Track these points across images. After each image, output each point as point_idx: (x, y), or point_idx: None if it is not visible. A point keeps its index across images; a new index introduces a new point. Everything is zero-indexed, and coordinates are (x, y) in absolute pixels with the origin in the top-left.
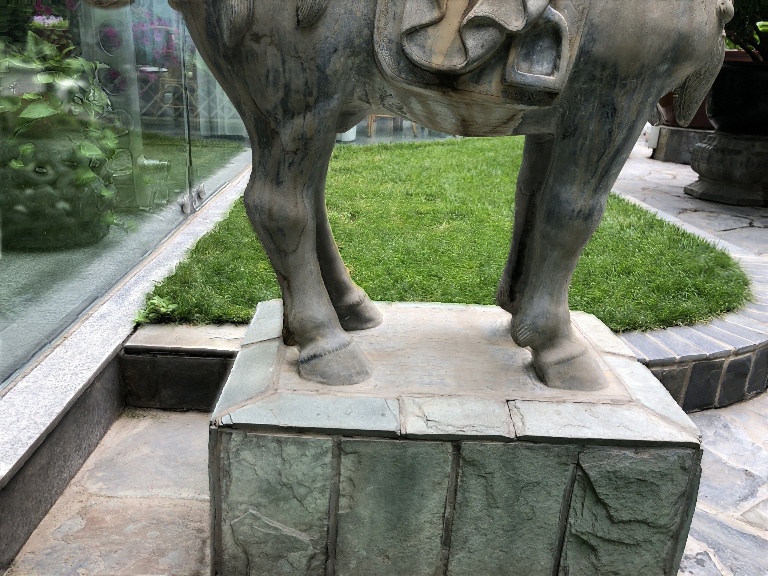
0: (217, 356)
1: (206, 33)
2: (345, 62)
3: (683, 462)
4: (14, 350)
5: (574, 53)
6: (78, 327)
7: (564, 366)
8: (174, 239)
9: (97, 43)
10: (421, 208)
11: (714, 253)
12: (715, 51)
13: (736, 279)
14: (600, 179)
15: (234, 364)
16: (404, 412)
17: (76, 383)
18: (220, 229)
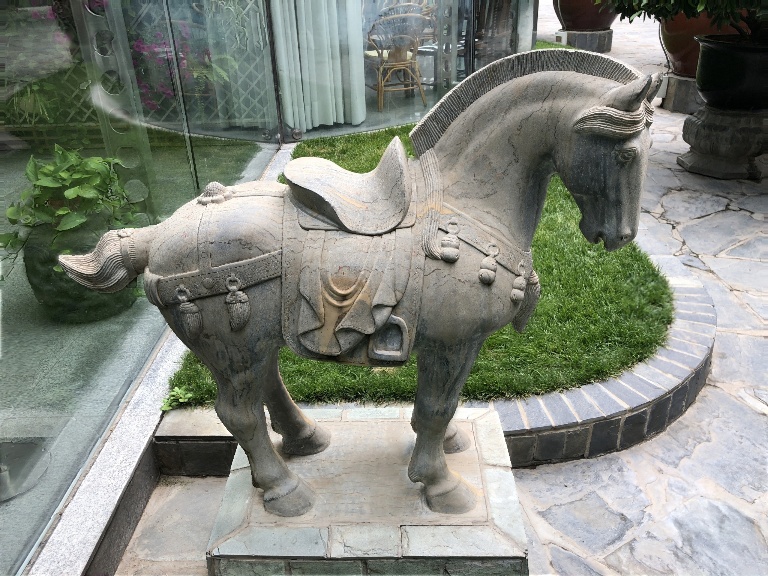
0: (223, 440)
1: (175, 328)
2: (266, 343)
3: (514, 567)
4: (76, 447)
5: (413, 337)
6: (120, 418)
7: (441, 498)
8: None
9: (109, 128)
10: None
11: (654, 282)
12: (531, 294)
13: (662, 317)
14: (449, 393)
15: None
16: (331, 539)
17: (122, 481)
18: None
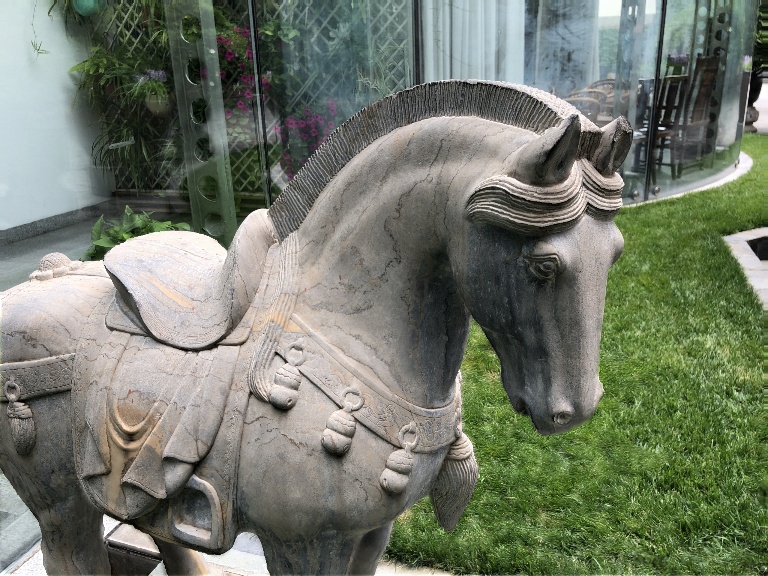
0: None
1: None
2: (66, 478)
3: None
4: (27, 533)
5: (230, 515)
6: None
7: None
8: None
9: (199, 194)
10: None
11: None
12: (453, 476)
13: None
14: None
15: None
16: None
17: None
18: None
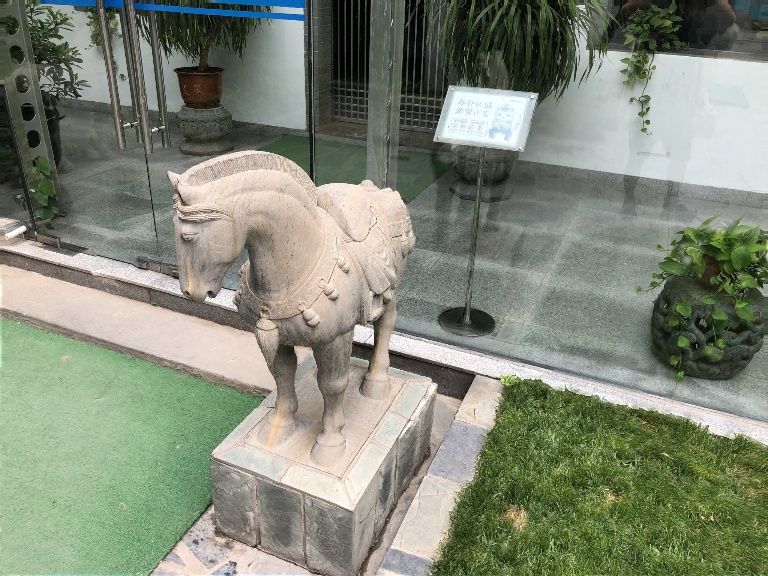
0: None
1: None
2: None
3: None
4: (479, 345)
5: None
6: (504, 362)
7: None
8: (704, 413)
9: None
10: None
11: None
12: None
13: None
14: None
15: None
16: None
17: (436, 359)
18: None
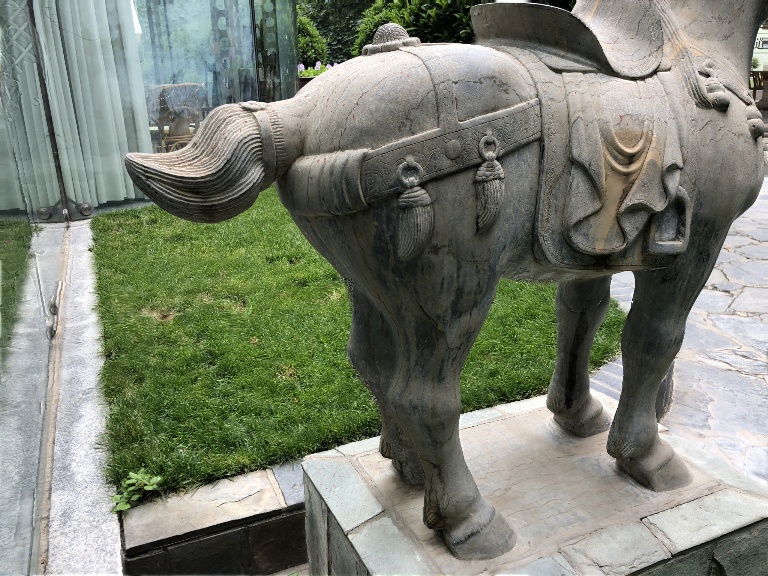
0: (237, 526)
1: (373, 249)
2: (508, 255)
3: None
4: None
5: (690, 218)
6: (47, 542)
7: (665, 470)
8: (59, 378)
9: None
10: (296, 277)
11: None
12: None
13: None
14: (689, 309)
15: (365, 561)
16: (576, 565)
17: None
18: (107, 351)
